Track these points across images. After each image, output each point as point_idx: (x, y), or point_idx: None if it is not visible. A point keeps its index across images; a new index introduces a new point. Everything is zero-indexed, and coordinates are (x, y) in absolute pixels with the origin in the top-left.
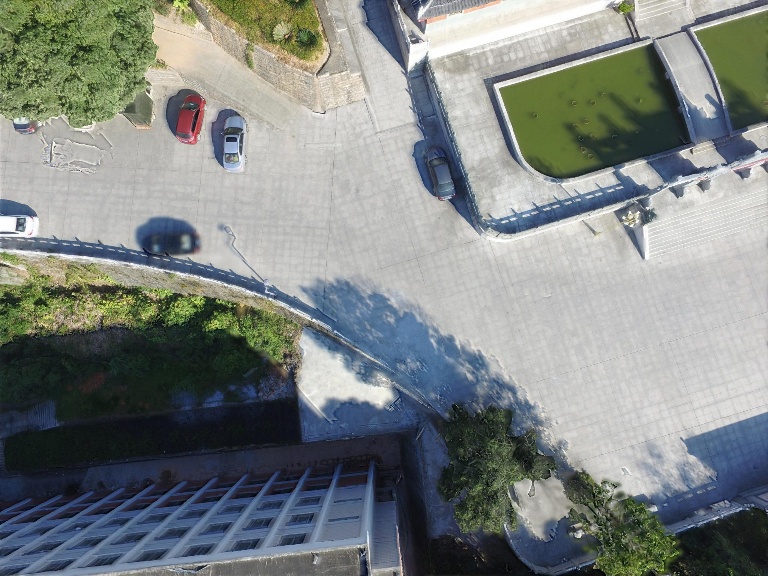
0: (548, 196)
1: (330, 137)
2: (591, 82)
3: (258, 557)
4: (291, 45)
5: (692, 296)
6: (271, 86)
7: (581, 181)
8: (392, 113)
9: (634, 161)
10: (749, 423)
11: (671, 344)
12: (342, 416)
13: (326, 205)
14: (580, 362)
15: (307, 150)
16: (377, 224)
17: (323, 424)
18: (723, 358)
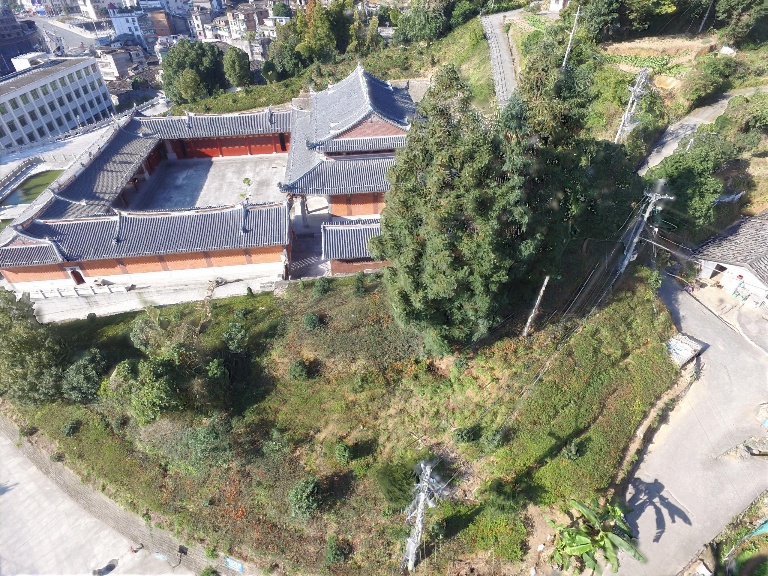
0: None
1: None
2: None
3: None
4: None
5: None
6: None
7: None
8: None
9: (8, 194)
10: None
11: None
12: None
13: None
14: None
15: None
16: None
17: None
18: None
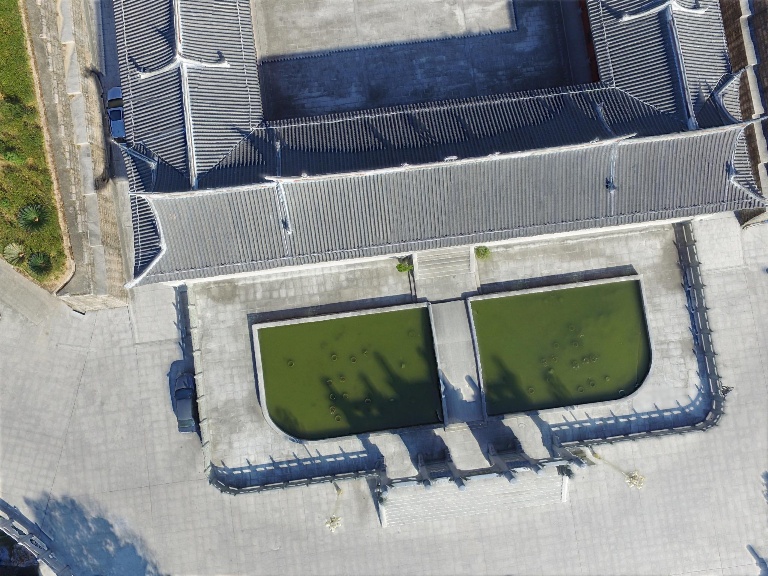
0: (287, 452)
1: (85, 341)
2: (357, 337)
3: None
4: (24, 266)
5: (423, 573)
6: None
7: None
8: (154, 326)
9: (380, 433)
10: None
11: None
12: None
13: (66, 414)
14: None
15: (58, 351)
16: (116, 443)
17: None
18: None
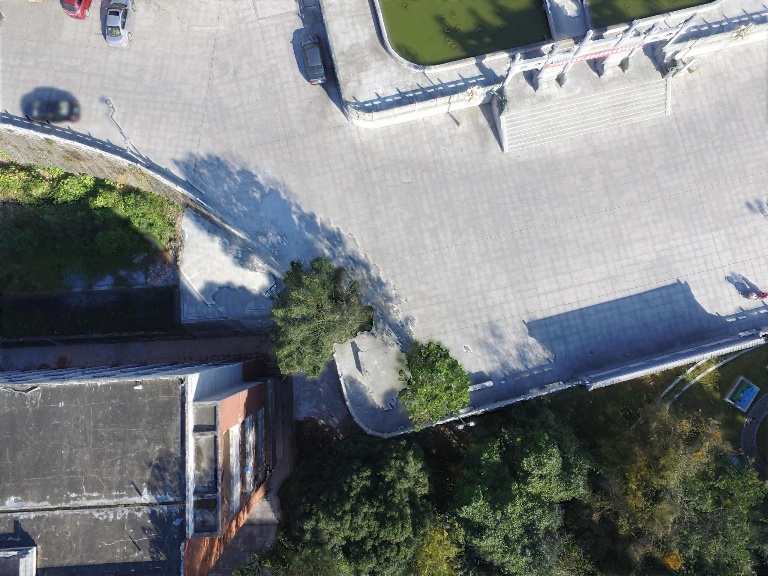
0: (412, 83)
1: (213, 20)
2: None
3: (84, 381)
4: None
5: (546, 189)
6: None
7: (444, 70)
8: (274, 1)
9: (495, 53)
10: (590, 311)
11: (522, 233)
12: (220, 300)
13: (204, 84)
14: (433, 245)
15: (190, 32)
16: (251, 105)
17: (202, 307)
18: (571, 249)
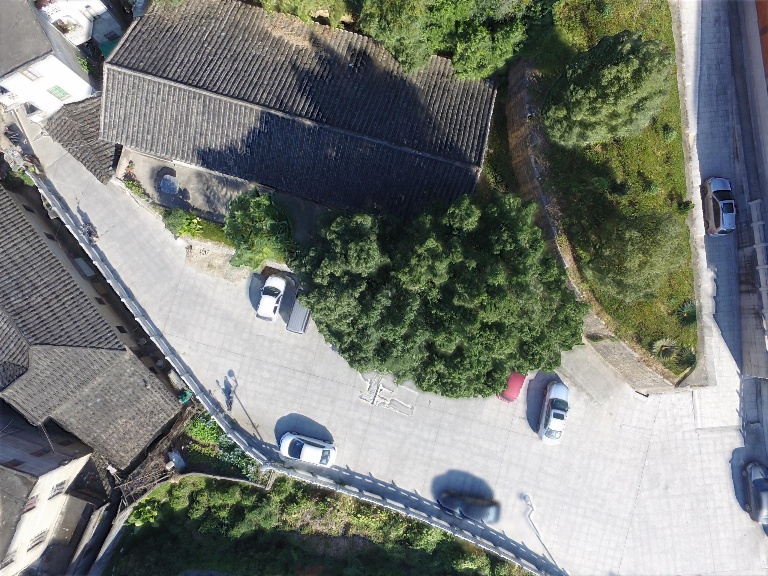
0: None
1: (649, 423)
2: None
3: None
4: (667, 359)
5: None
6: (601, 358)
7: None
8: (717, 412)
9: None
10: None
11: None
12: None
13: (632, 495)
14: None
15: (622, 432)
16: (681, 527)
17: None
18: None
